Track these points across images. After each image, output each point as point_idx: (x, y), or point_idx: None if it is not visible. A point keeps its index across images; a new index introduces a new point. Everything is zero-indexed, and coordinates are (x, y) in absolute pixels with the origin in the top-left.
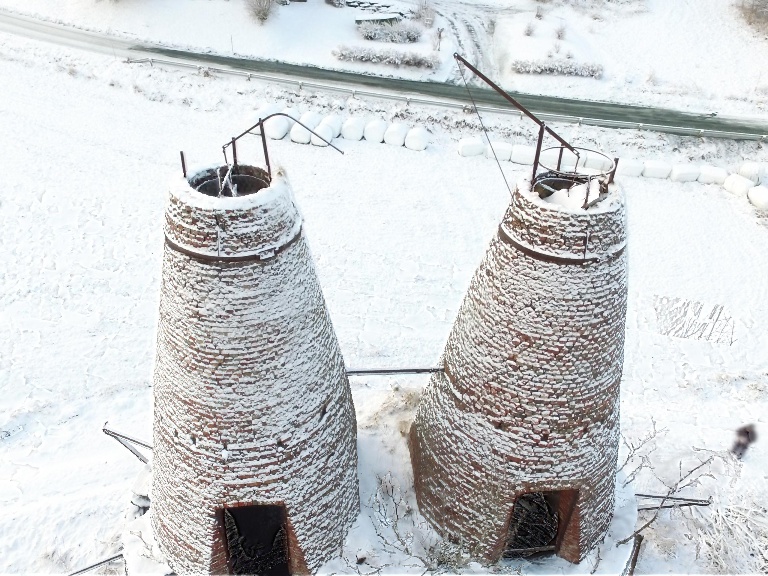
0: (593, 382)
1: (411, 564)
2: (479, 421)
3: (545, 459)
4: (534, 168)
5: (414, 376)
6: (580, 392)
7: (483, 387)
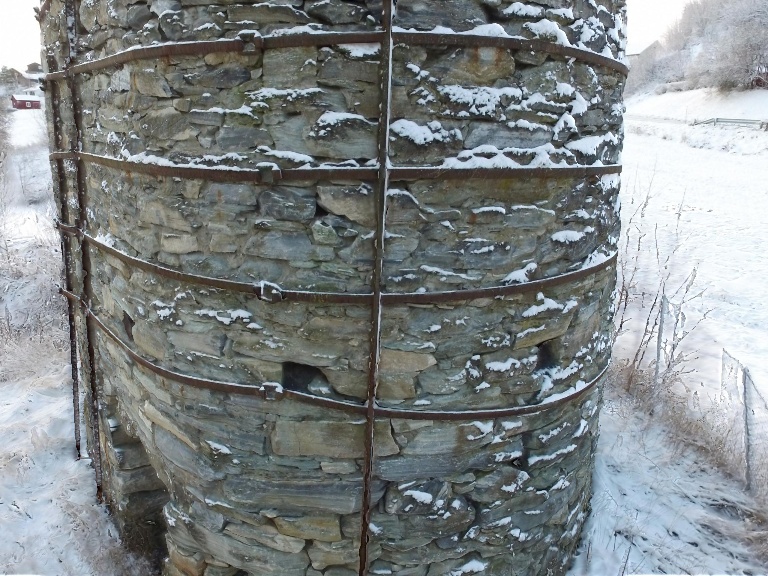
0: None
1: None
2: None
3: None
4: None
5: (758, 330)
6: None
7: None
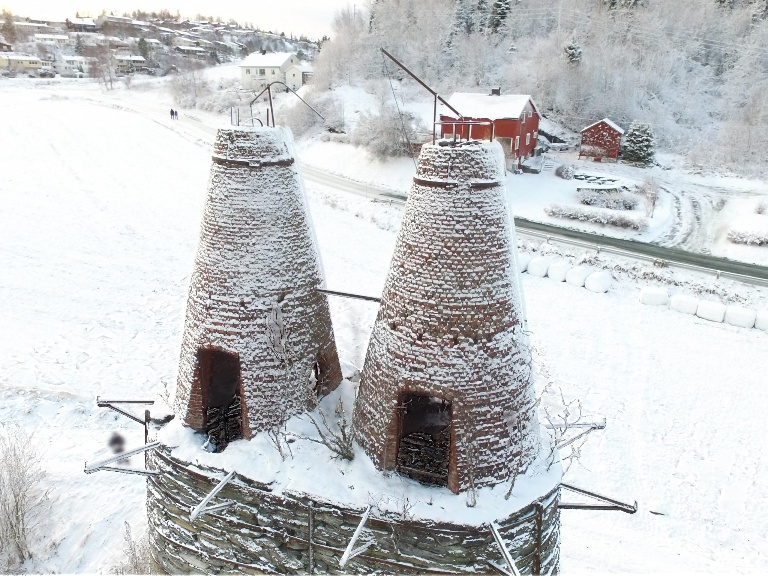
0: (459, 293)
1: (323, 451)
2: (384, 325)
3: (420, 359)
4: (434, 128)
5: None
6: (447, 299)
7: (388, 295)
